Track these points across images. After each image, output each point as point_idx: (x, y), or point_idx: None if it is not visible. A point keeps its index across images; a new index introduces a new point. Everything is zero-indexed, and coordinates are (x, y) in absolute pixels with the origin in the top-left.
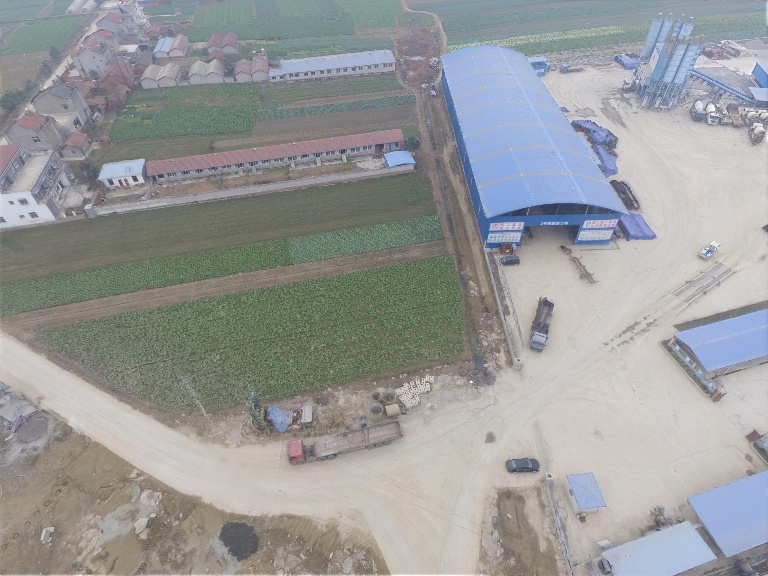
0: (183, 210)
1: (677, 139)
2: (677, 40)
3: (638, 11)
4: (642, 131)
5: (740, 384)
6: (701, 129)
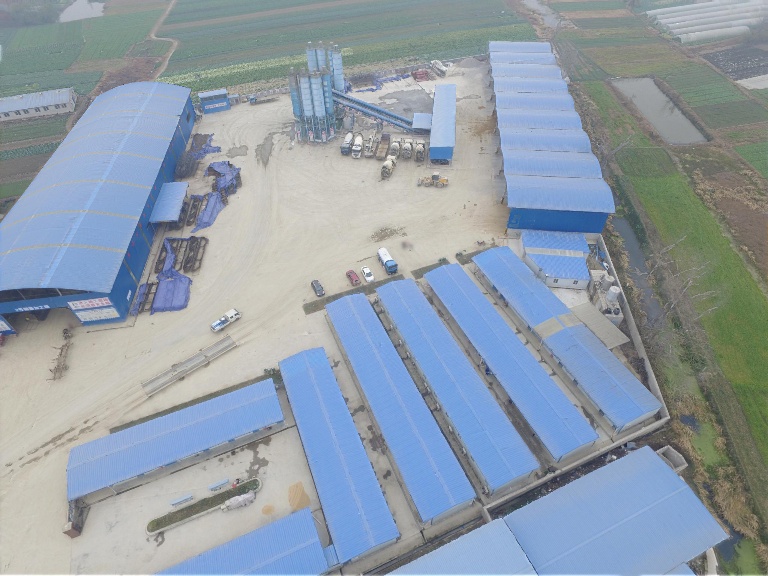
0: None
1: (308, 178)
2: (298, 73)
3: (385, 30)
4: (279, 171)
5: (124, 506)
6: (342, 164)
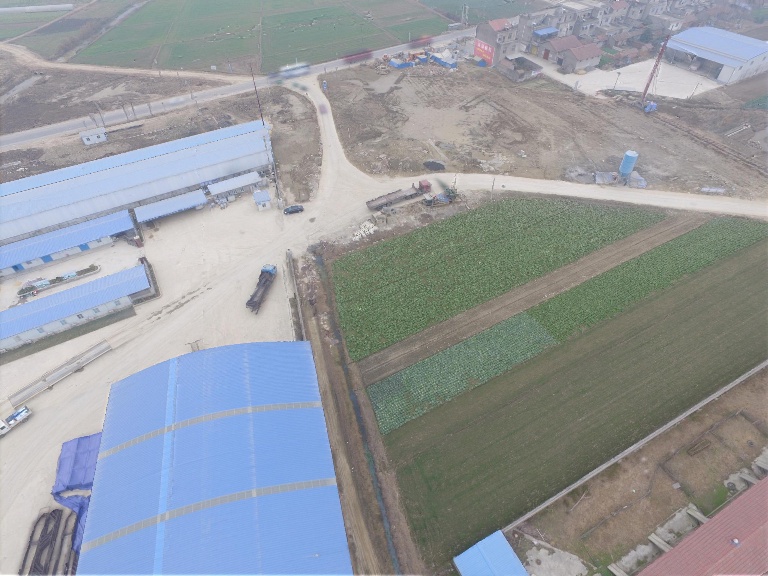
0: (737, 358)
1: None
2: None
3: None
4: None
5: None
6: None
